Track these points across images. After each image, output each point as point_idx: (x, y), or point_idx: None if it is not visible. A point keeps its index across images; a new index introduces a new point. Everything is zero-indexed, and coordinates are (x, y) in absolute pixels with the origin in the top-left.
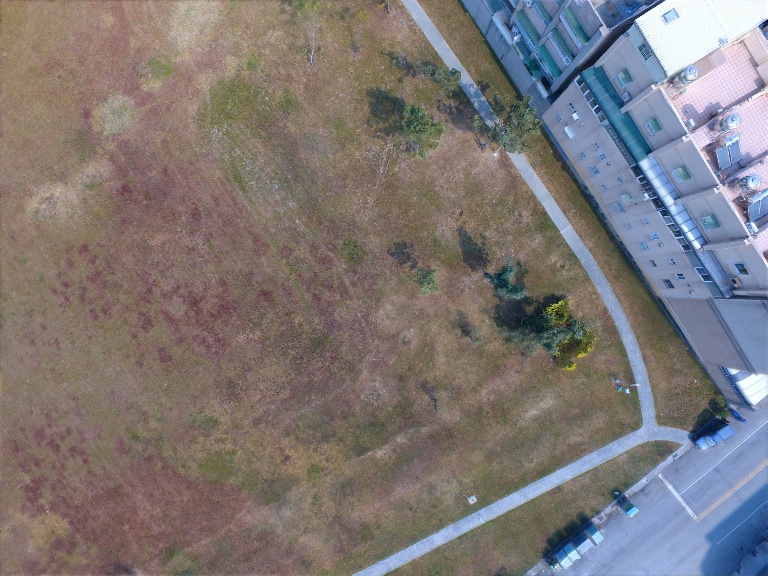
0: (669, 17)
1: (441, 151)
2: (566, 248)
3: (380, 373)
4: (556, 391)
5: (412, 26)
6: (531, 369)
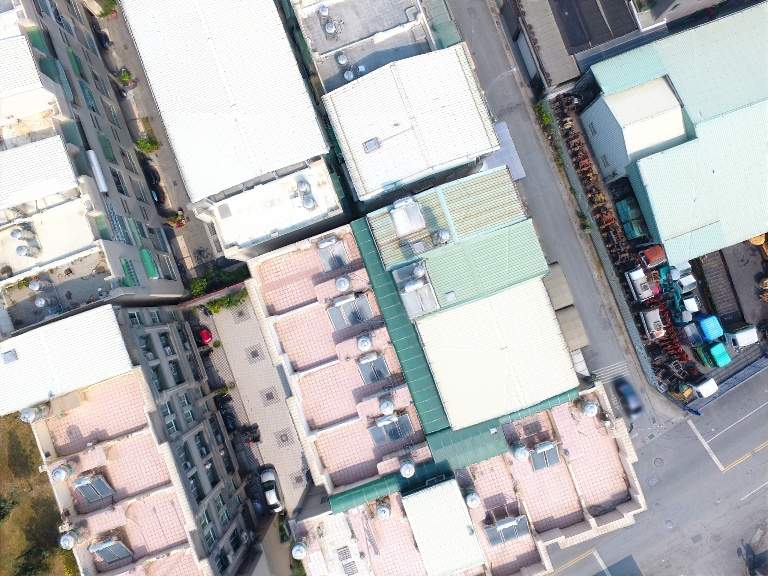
0: (7, 358)
1: None
2: None
3: None
4: None
5: None
6: None
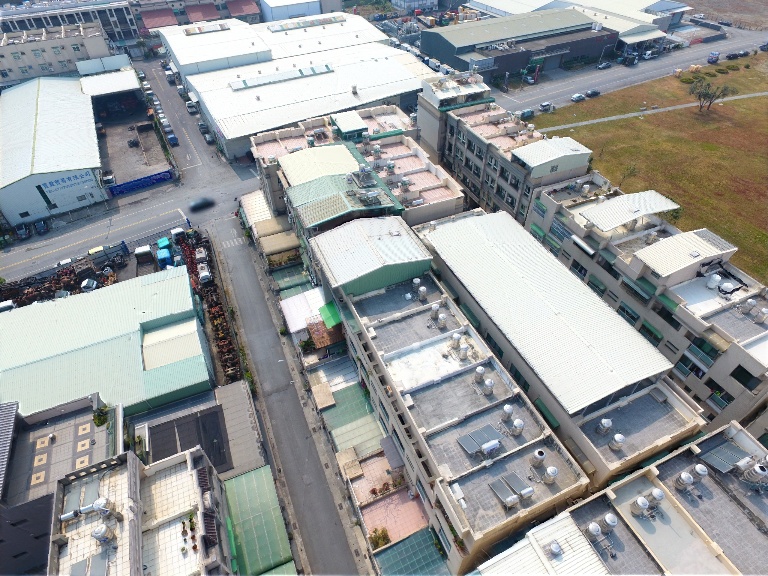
0: None
1: None
2: None
3: None
4: None
5: None
6: None
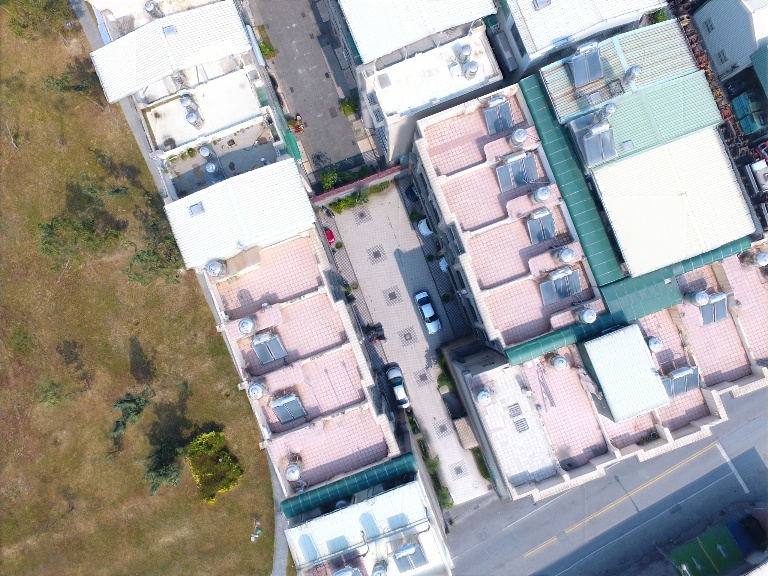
0: (194, 210)
1: (129, 257)
2: (236, 377)
3: (24, 470)
4: (195, 521)
5: (124, 128)
6: (174, 494)
